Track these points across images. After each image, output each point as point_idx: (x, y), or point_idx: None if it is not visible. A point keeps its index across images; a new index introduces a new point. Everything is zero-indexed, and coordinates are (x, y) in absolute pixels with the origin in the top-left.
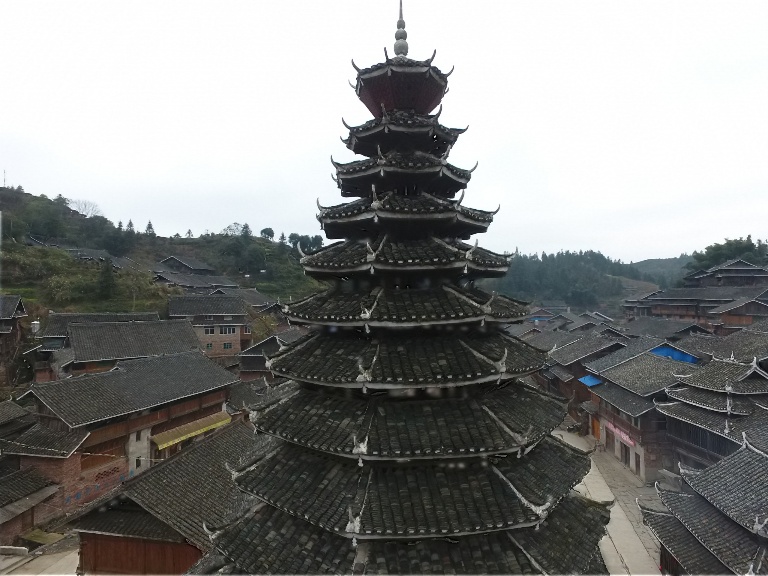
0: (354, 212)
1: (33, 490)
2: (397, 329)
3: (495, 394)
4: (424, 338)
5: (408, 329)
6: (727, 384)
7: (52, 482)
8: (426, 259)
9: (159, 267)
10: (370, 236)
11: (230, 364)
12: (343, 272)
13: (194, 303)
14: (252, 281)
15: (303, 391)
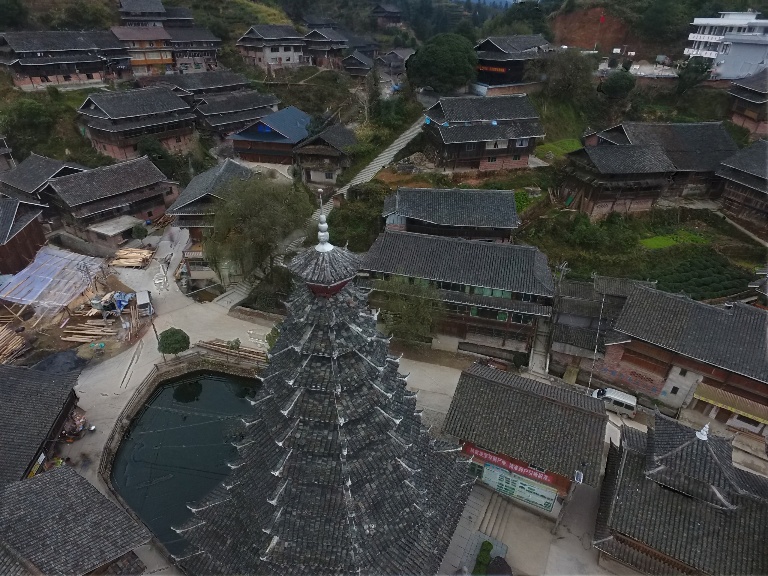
0: None
1: (589, 348)
2: None
3: None
4: None
5: None
6: None
7: (605, 352)
8: None
9: None
10: None
11: None
12: None
13: None
14: None
15: None
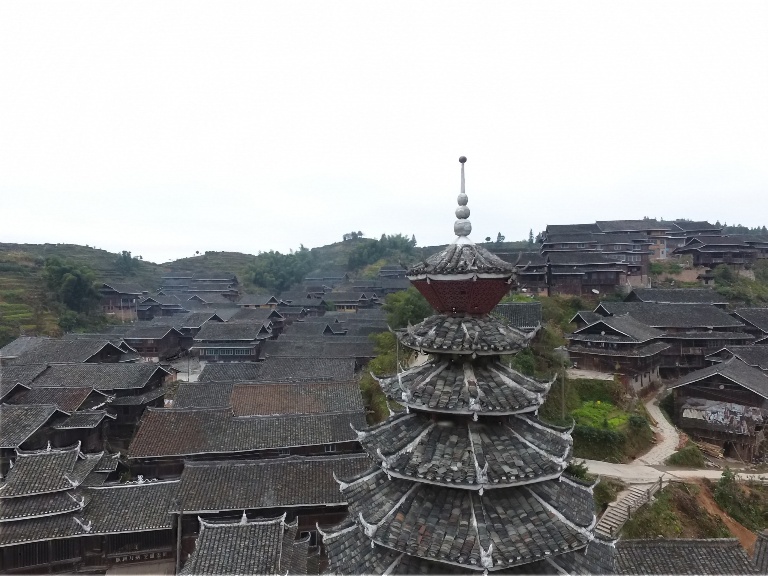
0: None
1: None
2: None
3: None
4: None
5: None
6: (70, 479)
7: None
8: None
9: None
10: None
11: None
12: None
13: None
14: None
15: None
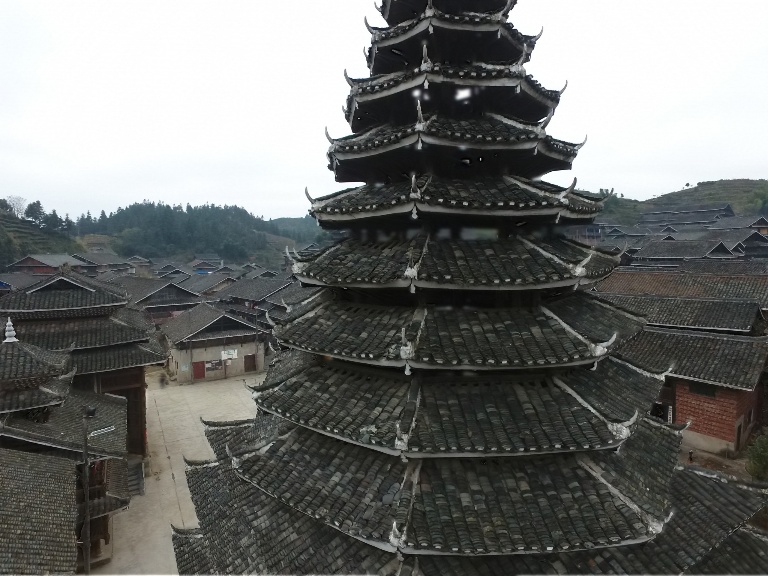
0: (492, 74)
1: None
2: None
3: None
4: None
5: (565, 222)
6: None
7: None
8: None
9: None
10: (465, 113)
11: None
12: (491, 149)
13: None
14: None
15: (429, 309)
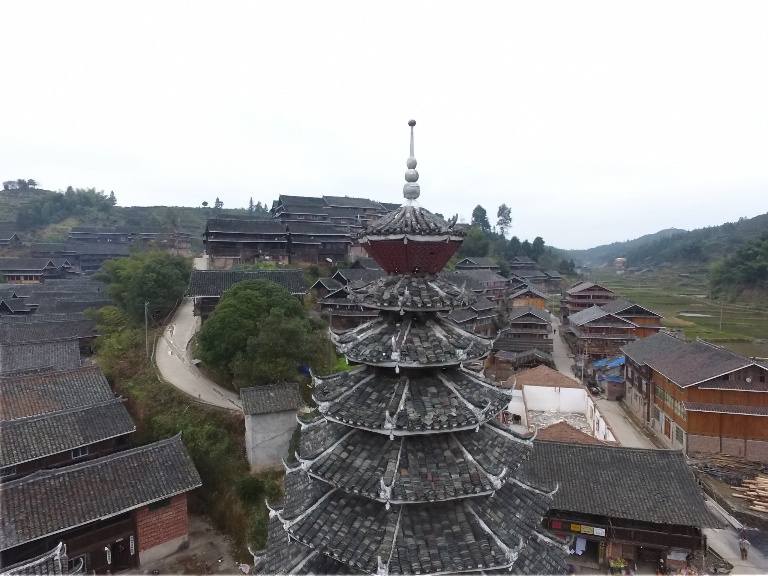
0: None
1: None
2: None
3: None
4: None
5: None
6: None
7: None
8: None
9: None
10: None
11: None
12: None
13: None
14: None
15: None
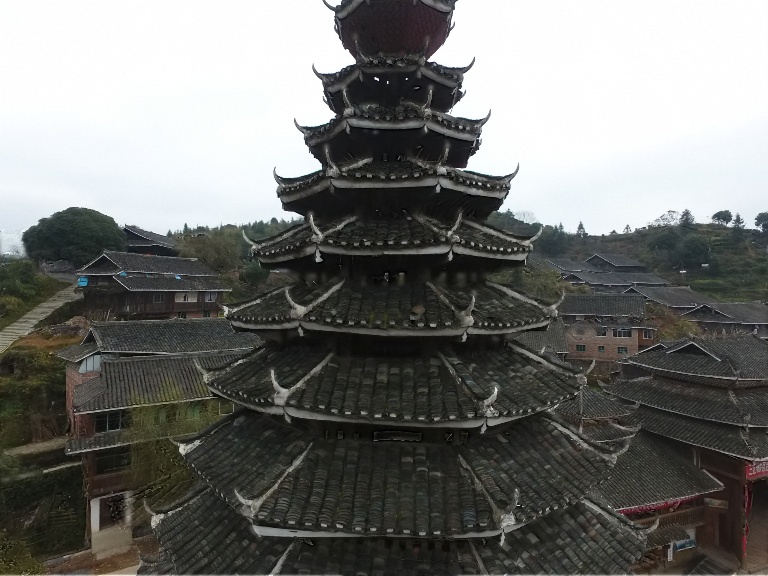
0: None
1: None
2: (257, 332)
3: (368, 444)
4: (295, 346)
5: None
6: None
7: None
8: (283, 248)
9: (580, 266)
10: None
11: (613, 371)
12: None
13: (587, 302)
14: (689, 278)
15: None
